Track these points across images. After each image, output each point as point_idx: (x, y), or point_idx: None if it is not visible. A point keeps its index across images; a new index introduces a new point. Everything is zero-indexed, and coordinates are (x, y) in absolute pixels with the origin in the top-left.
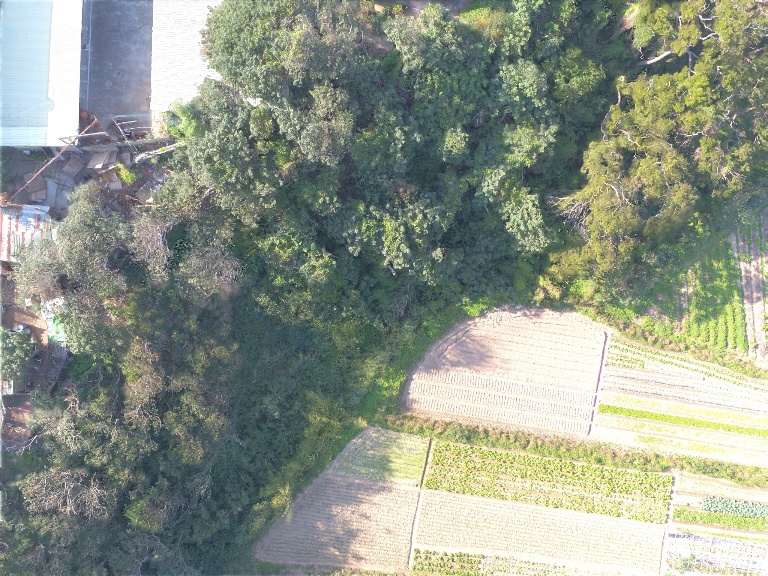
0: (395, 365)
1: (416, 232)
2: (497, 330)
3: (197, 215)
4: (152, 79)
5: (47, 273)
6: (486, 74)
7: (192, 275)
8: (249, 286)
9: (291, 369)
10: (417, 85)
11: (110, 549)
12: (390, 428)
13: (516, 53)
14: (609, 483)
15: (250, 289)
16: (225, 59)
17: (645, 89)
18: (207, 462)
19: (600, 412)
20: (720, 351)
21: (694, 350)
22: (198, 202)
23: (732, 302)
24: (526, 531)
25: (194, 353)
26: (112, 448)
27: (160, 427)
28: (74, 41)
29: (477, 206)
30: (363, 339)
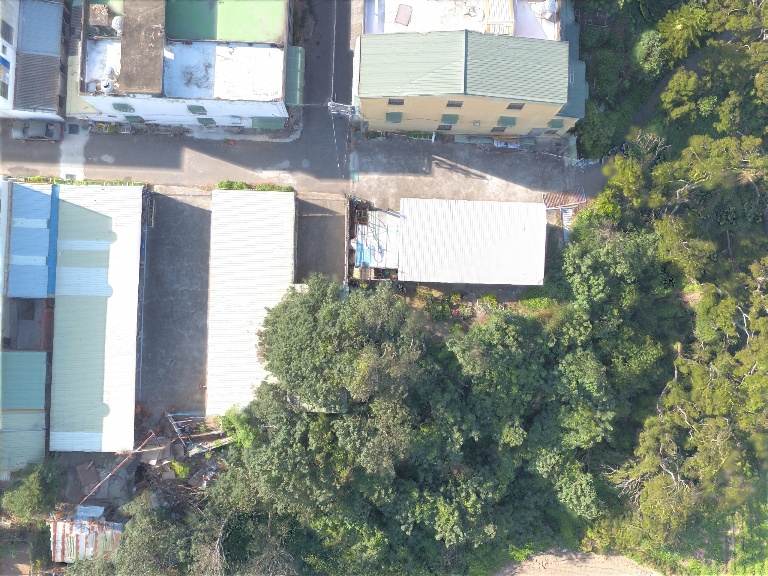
0: None
1: (469, 512)
2: (543, 574)
3: (251, 509)
4: (208, 383)
5: None
6: (544, 362)
7: None
8: (298, 548)
9: None
10: (475, 381)
11: None
12: None
13: (575, 343)
14: None
15: (299, 550)
16: (284, 372)
17: (706, 383)
18: None
19: None
20: None
21: None
22: (253, 502)
23: None
24: None
25: None
26: None
27: None
28: (129, 341)
29: None
30: None
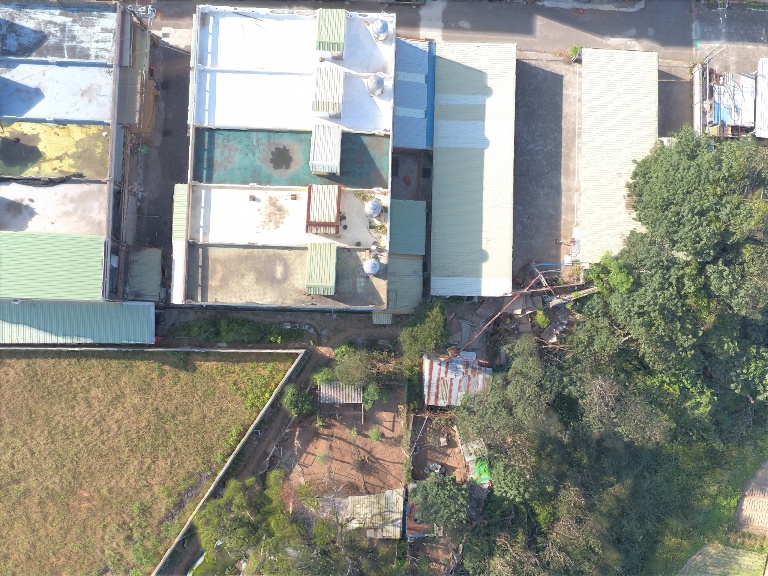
0: (734, 484)
1: None
2: None
3: (608, 359)
4: (582, 232)
5: None
6: None
7: (620, 424)
8: None
9: (641, 489)
10: None
11: None
12: (730, 545)
13: None
14: None
15: None
16: (663, 217)
17: None
18: None
19: None
20: None
21: None
22: (616, 349)
23: None
24: None
25: (593, 489)
26: None
27: (572, 565)
28: (503, 192)
29: None
30: None
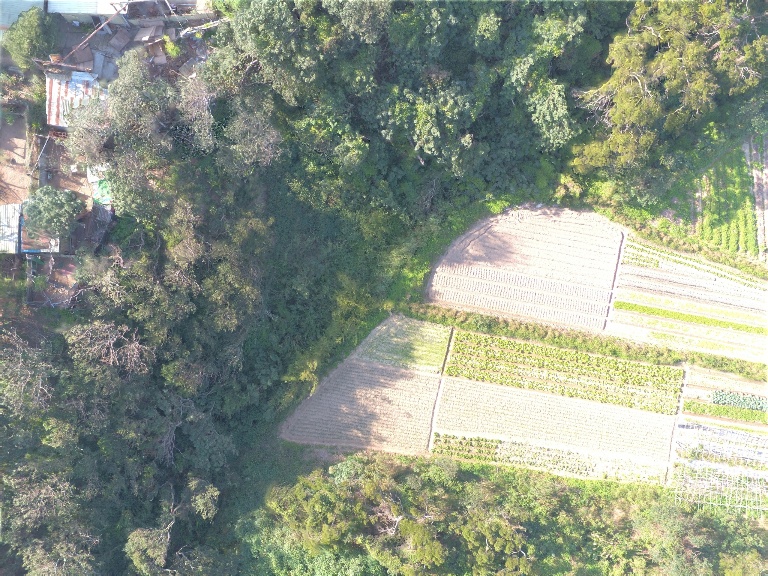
0: (420, 256)
1: (447, 117)
2: (518, 227)
3: (239, 89)
4: None
5: (96, 133)
6: None
7: (234, 141)
8: (283, 171)
9: (320, 255)
10: None
11: (147, 408)
12: (414, 316)
13: None
14: (623, 374)
15: (283, 174)
16: None
17: None
18: (239, 336)
19: (615, 308)
20: (731, 253)
21: (707, 251)
22: (241, 75)
23: (744, 208)
24: (542, 418)
25: (232, 224)
26: (154, 305)
27: (199, 291)
28: None
29: (504, 101)
30: (390, 229)
